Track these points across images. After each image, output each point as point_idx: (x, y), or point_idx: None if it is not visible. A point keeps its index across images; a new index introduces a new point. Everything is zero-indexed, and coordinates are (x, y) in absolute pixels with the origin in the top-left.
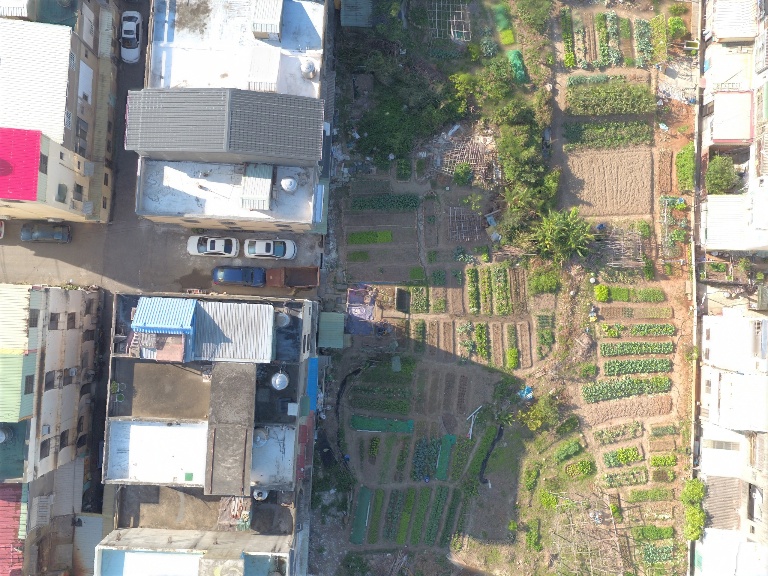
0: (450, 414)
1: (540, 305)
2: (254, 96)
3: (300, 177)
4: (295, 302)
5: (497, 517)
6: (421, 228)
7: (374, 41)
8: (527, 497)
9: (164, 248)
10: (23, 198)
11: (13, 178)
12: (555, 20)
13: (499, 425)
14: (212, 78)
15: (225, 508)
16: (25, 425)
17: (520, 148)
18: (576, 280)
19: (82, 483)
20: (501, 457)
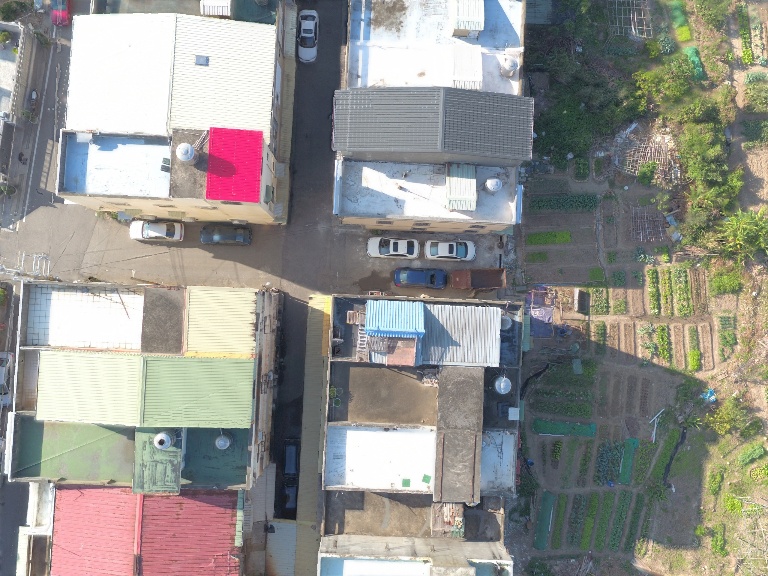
0: (632, 417)
1: (721, 306)
2: (467, 95)
3: (499, 177)
4: (511, 304)
5: (681, 522)
6: (600, 228)
7: (551, 38)
8: (712, 502)
9: (343, 250)
10: (246, 200)
11: (236, 180)
12: (731, 16)
13: (682, 428)
14: (410, 77)
15: (437, 514)
16: (243, 431)
17: (706, 146)
18: (758, 280)
19: (274, 489)
20: (685, 461)
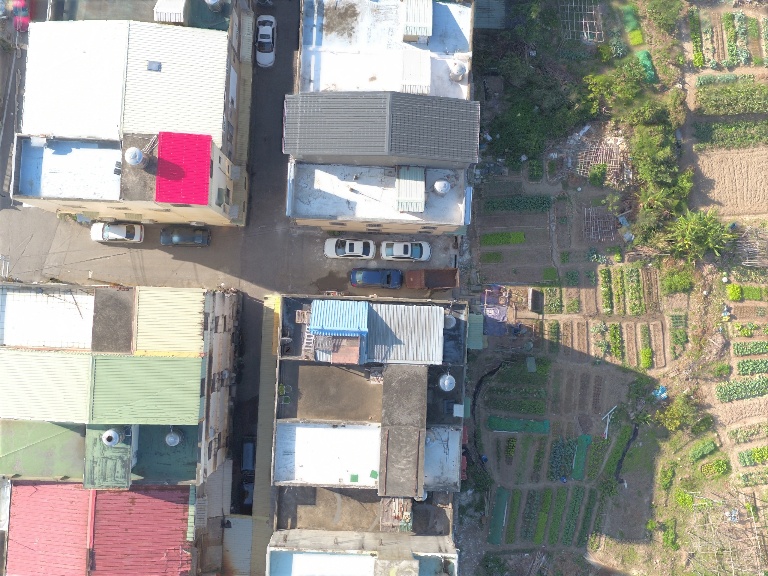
0: (585, 414)
1: (673, 305)
2: (413, 99)
3: (449, 179)
4: (457, 304)
5: (633, 517)
6: (553, 229)
7: (505, 43)
8: (663, 497)
9: (300, 251)
10: (195, 202)
11: (185, 183)
12: (683, 20)
13: (634, 425)
14: (361, 81)
15: (386, 509)
16: (194, 428)
17: (656, 148)
18: (708, 280)
19: (230, 485)
20: (637, 457)
